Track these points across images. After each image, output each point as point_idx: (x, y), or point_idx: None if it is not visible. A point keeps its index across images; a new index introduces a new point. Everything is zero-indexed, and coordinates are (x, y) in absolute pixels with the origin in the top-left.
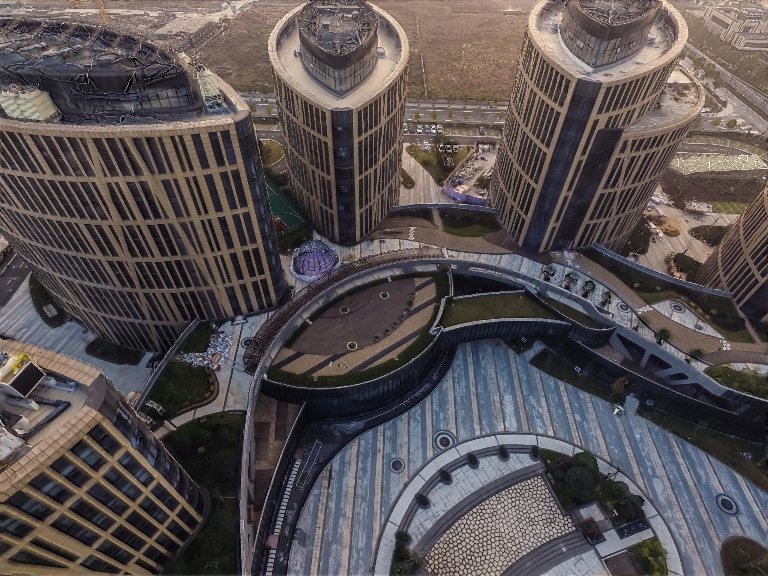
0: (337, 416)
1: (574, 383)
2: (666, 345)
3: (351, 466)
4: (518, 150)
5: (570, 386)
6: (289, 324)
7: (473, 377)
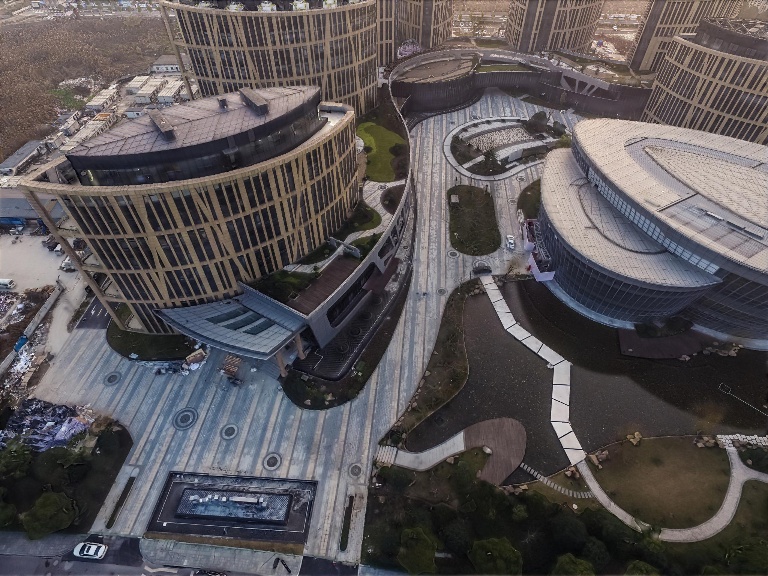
0: (423, 110)
1: (542, 105)
2: None
3: (431, 123)
4: None
5: (540, 106)
6: (402, 65)
7: (490, 103)
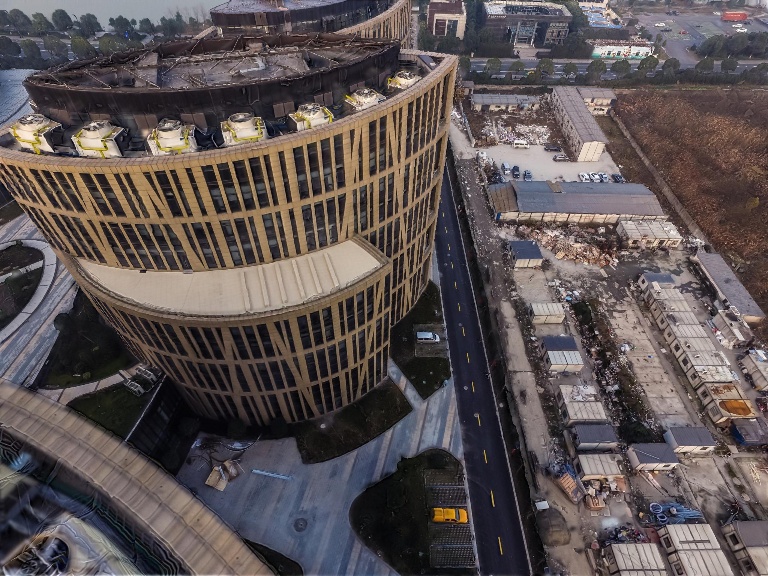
0: None
1: None
2: None
3: None
4: None
5: None
6: None
7: None
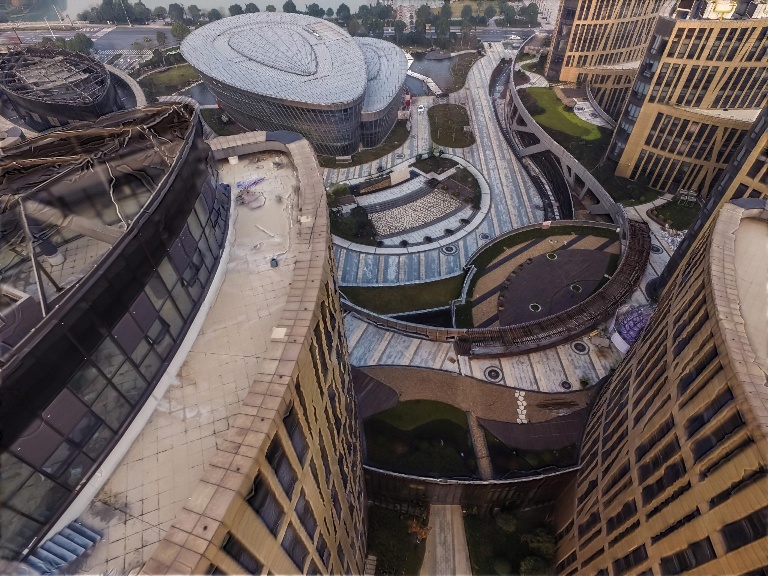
0: None
1: None
2: None
3: None
4: None
5: None
6: None
7: None
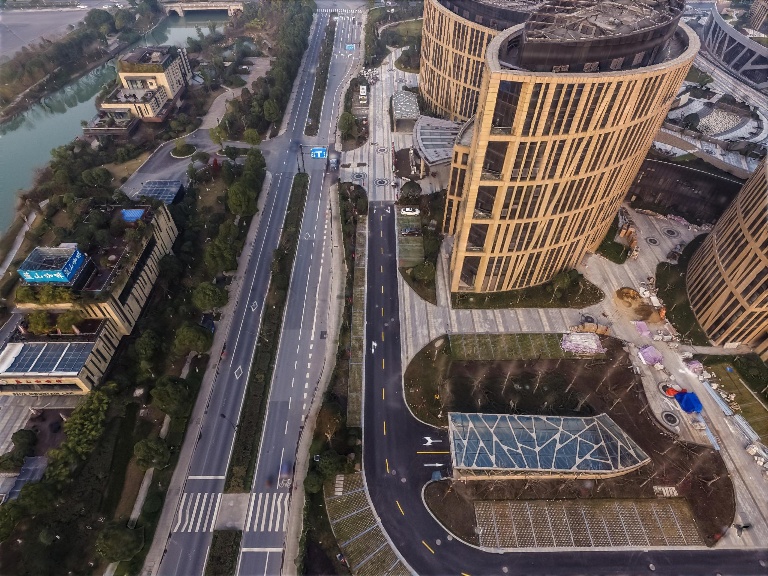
0: None
1: None
2: (675, 134)
3: None
4: None
5: None
6: None
7: None
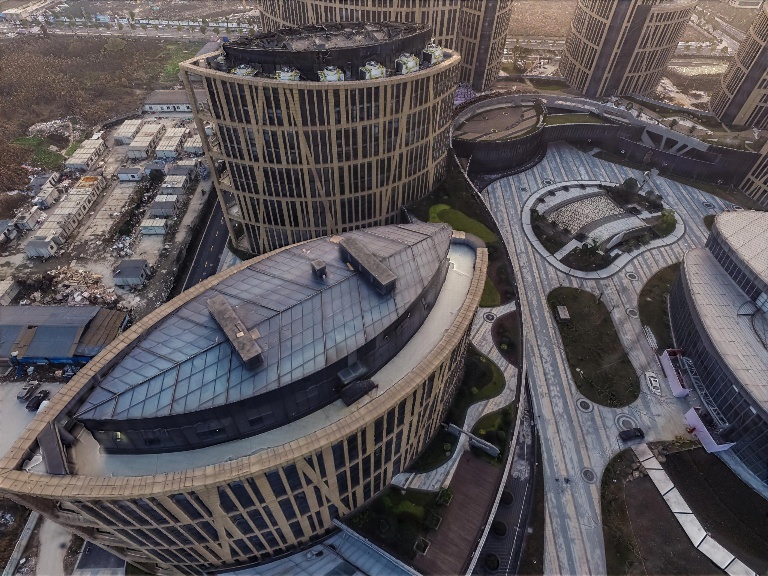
0: (485, 171)
1: (620, 163)
2: None
3: (498, 189)
4: (586, 30)
5: (618, 165)
6: (459, 117)
7: (559, 160)
